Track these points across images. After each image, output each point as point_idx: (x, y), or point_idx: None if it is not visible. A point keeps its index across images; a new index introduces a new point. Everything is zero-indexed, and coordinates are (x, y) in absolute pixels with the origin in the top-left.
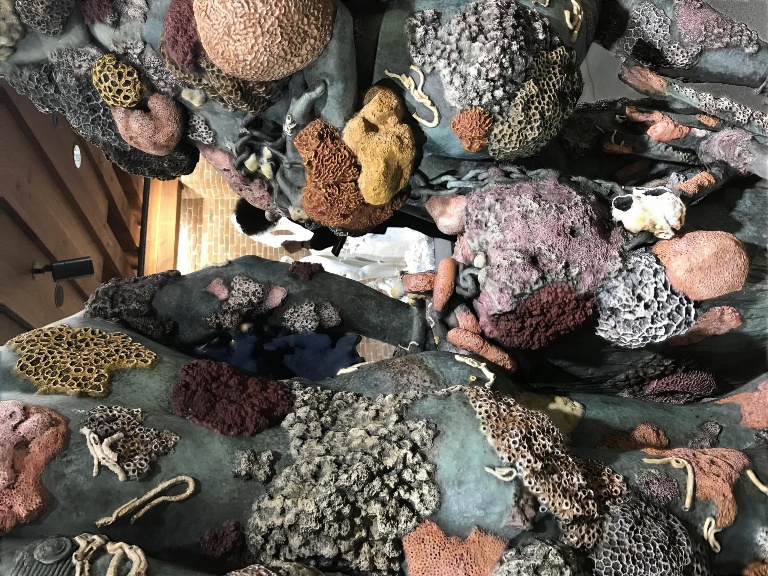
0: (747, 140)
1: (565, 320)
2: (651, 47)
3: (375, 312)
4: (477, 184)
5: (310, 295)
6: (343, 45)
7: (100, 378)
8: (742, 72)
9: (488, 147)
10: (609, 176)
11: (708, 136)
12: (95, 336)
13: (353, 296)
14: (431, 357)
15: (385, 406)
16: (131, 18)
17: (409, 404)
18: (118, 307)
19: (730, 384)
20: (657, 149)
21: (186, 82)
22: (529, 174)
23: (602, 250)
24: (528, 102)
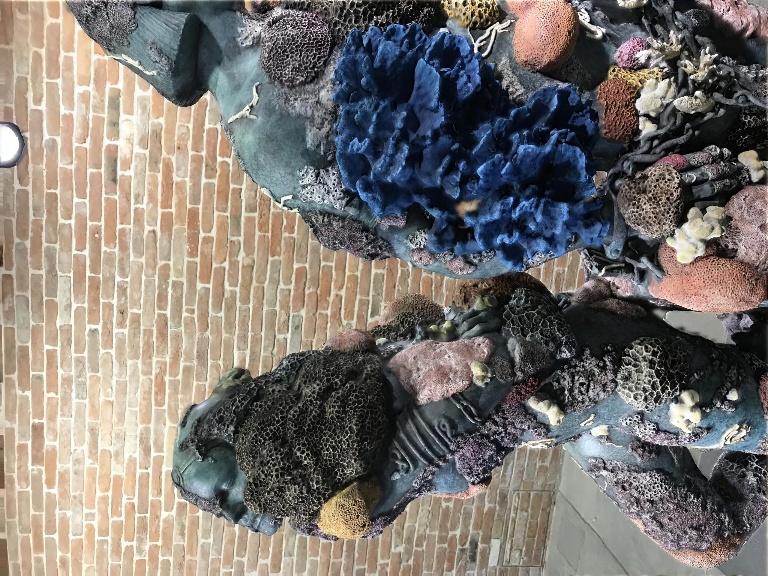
0: None
1: None
2: (735, 452)
3: None
4: None
5: None
6: None
7: None
8: None
9: None
10: None
11: None
12: None
13: None
14: None
15: None
16: None
17: None
18: None
19: None
20: None
21: (377, 331)
22: None
23: None
24: None
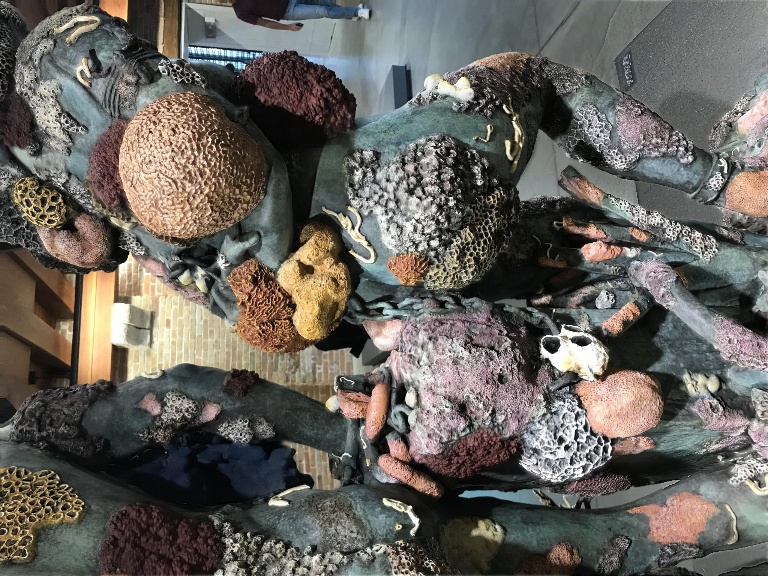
0: (671, 282)
1: (490, 458)
2: (592, 149)
3: (309, 425)
4: (412, 314)
5: (244, 411)
6: (278, 201)
7: (25, 540)
8: (676, 180)
9: (424, 283)
10: (544, 281)
11: (638, 256)
12: (20, 479)
13: (288, 410)
14: (360, 501)
15: (311, 570)
16: (54, 149)
17: (334, 572)
18: (46, 430)
19: (644, 478)
20: (590, 262)
21: None
22: (464, 302)
23: (528, 395)
24: (463, 249)
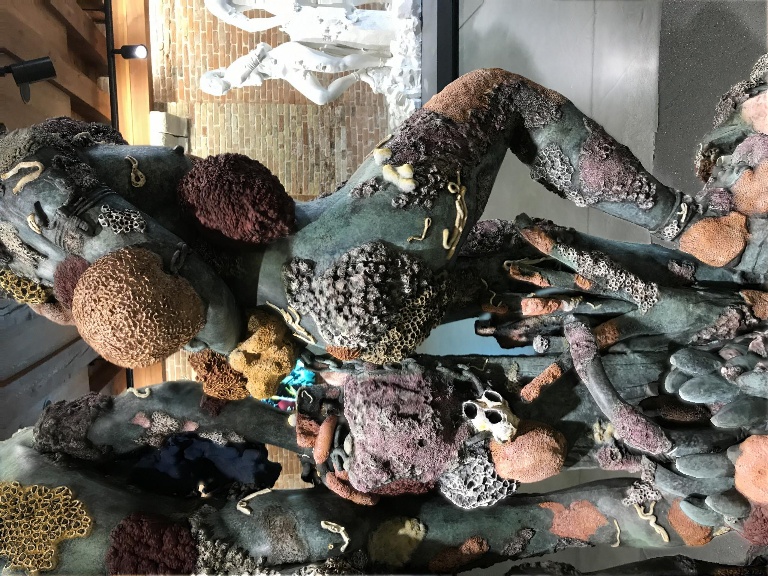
0: (588, 360)
1: None
2: (553, 186)
3: (274, 435)
4: (353, 373)
5: (218, 427)
6: (218, 325)
7: (48, 554)
8: (634, 221)
9: None
10: None
11: (575, 309)
12: (42, 497)
13: (255, 425)
14: (303, 523)
15: None
16: None
17: None
18: (59, 444)
19: None
20: None
21: None
22: None
23: (444, 453)
24: (391, 345)
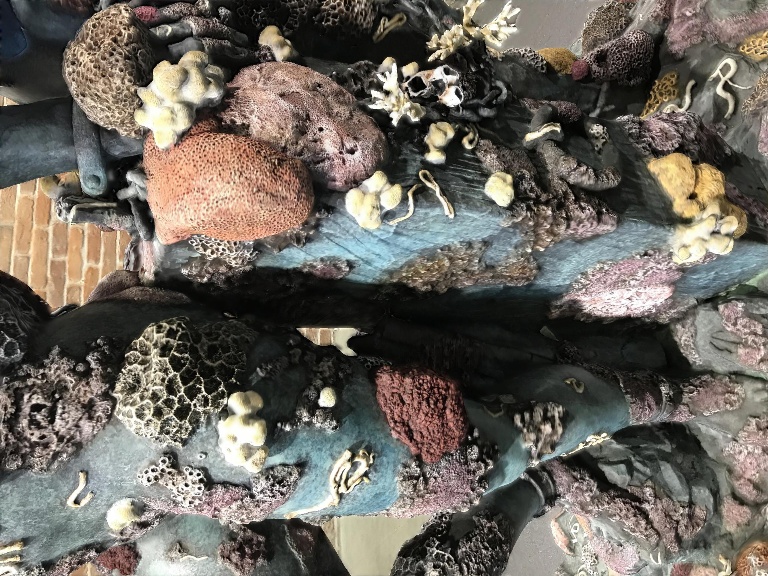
0: None
1: None
2: None
3: None
4: None
5: None
6: None
7: None
8: None
9: None
10: None
11: None
12: None
13: None
14: None
15: None
16: None
17: None
18: None
19: None
20: None
21: None
22: None
23: None
24: None
